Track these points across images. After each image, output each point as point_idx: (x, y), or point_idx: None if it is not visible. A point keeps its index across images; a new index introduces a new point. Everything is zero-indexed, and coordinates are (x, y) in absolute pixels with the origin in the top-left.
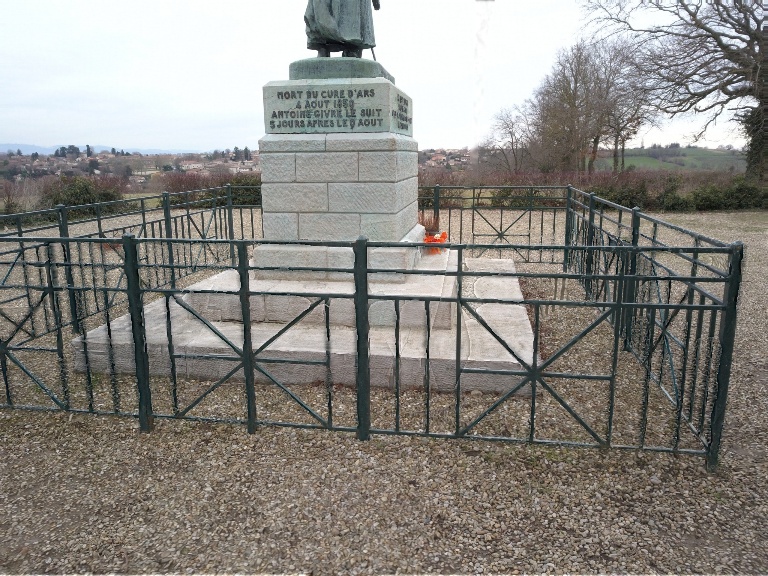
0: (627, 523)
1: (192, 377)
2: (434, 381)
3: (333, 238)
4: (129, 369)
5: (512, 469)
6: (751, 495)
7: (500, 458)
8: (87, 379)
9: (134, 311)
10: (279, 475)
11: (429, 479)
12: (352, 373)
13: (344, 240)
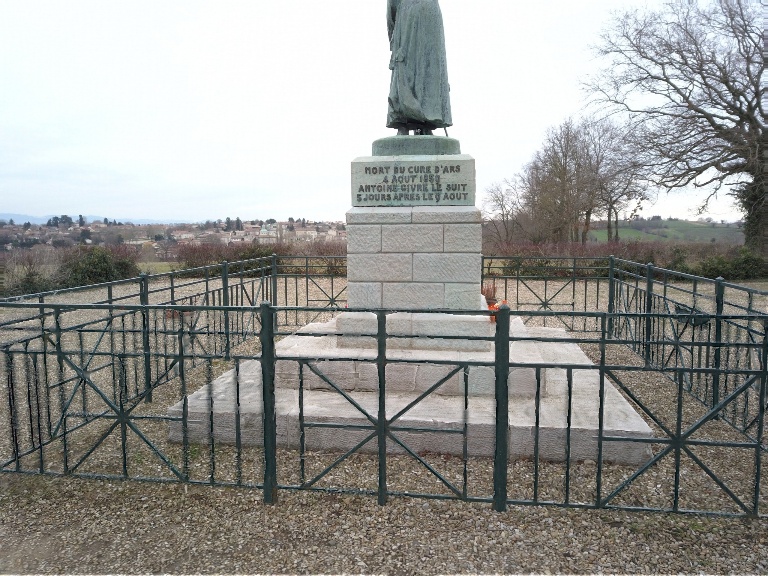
0: None
1: (293, 447)
2: (544, 450)
3: (417, 307)
4: (226, 439)
5: (662, 540)
6: None
7: (646, 529)
8: (184, 449)
9: (267, 379)
10: (428, 548)
11: (583, 551)
12: (460, 442)
13: None
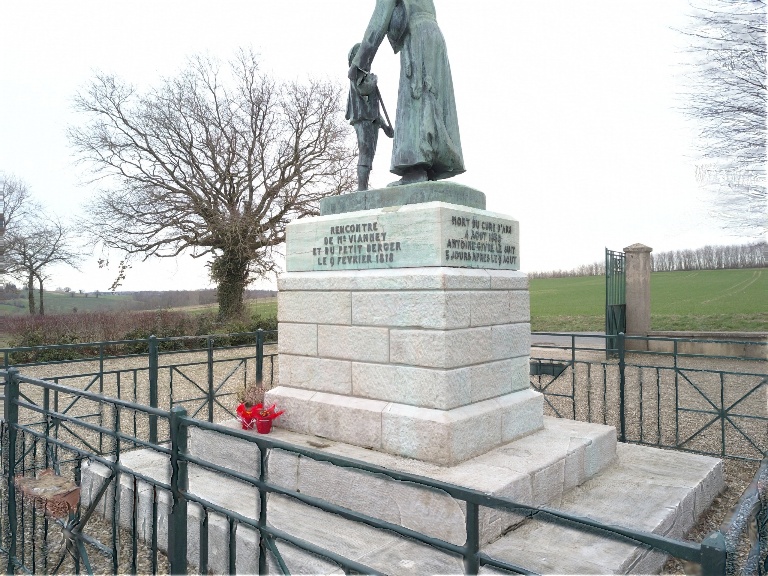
0: None
1: None
2: None
3: (495, 391)
4: None
5: None
6: None
7: None
8: None
9: None
10: None
11: None
12: None
13: (502, 391)
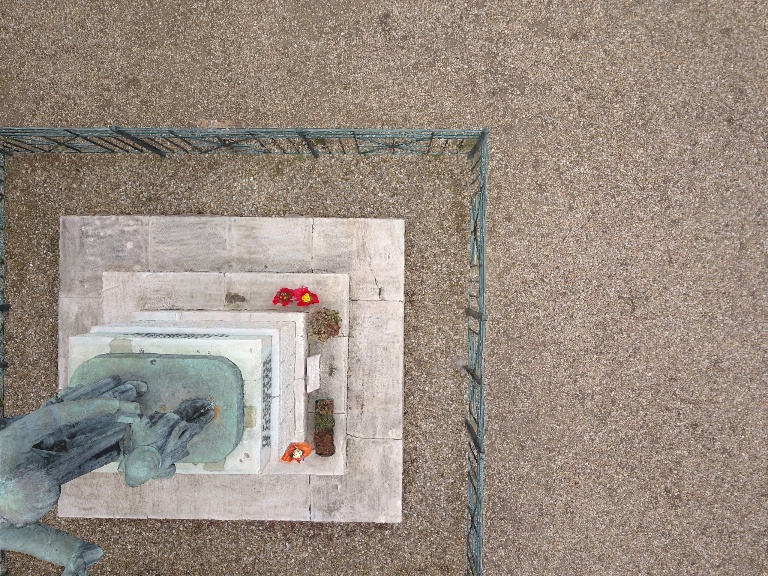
0: None
1: None
2: None
3: None
4: None
5: None
6: None
7: None
8: None
9: None
10: None
11: None
12: None
13: None
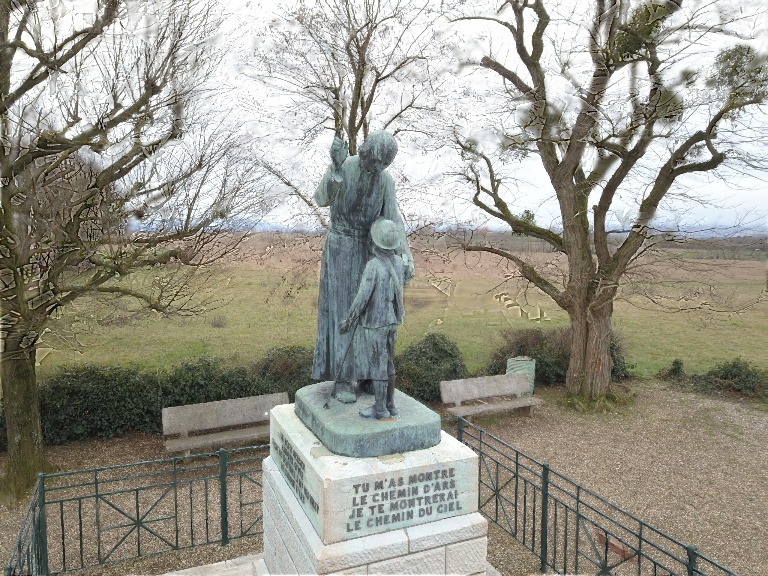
0: (103, 551)
1: None
2: None
3: None
4: None
5: None
6: None
7: None
8: None
9: None
10: None
11: (187, 541)
12: None
13: None
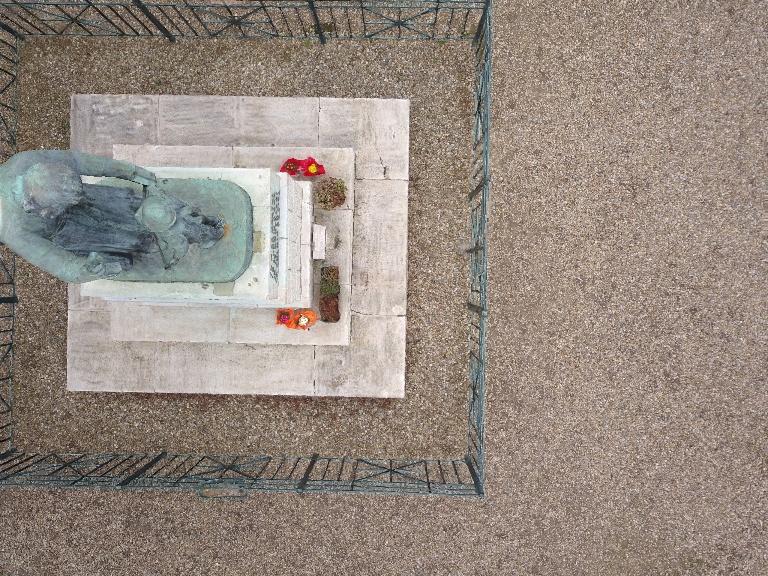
0: None
1: None
2: None
3: None
4: None
5: (3, 367)
6: (2, 460)
7: (8, 362)
8: None
9: None
10: None
11: None
12: None
13: None
